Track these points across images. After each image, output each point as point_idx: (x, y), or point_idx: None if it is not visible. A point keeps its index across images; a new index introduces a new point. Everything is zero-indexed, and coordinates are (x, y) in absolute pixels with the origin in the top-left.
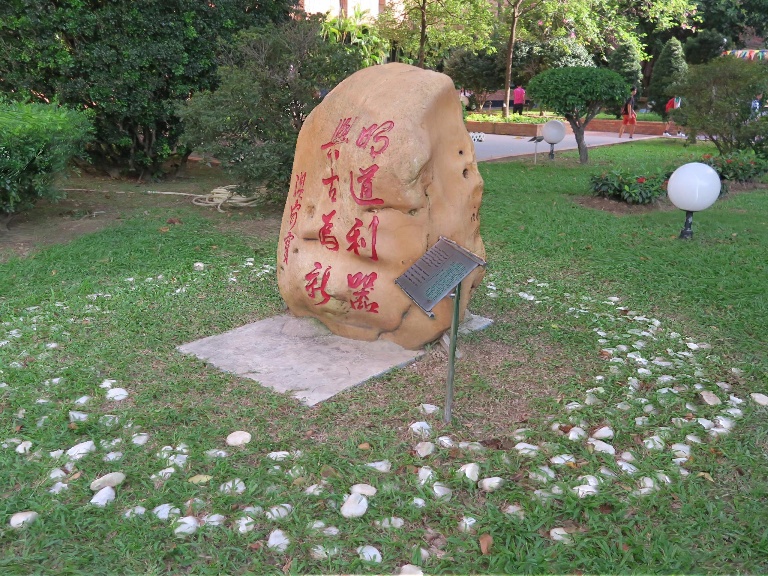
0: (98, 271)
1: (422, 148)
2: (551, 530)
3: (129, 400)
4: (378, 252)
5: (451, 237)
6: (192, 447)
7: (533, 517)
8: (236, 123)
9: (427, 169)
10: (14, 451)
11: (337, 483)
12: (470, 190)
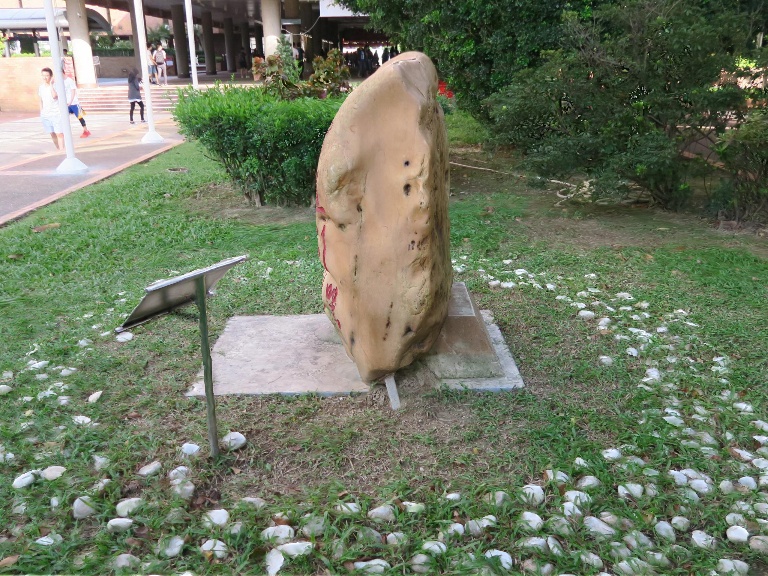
0: None
1: (344, 155)
2: None
3: (124, 344)
4: (327, 265)
5: (381, 264)
6: (67, 390)
7: (70, 570)
8: (533, 112)
9: (355, 180)
10: (25, 352)
11: (58, 458)
12: (408, 211)
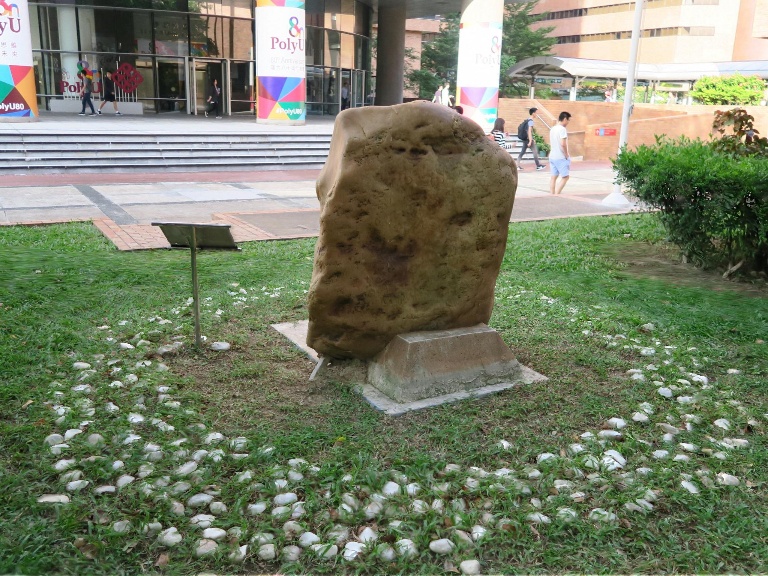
0: (625, 300)
1: None
2: (75, 353)
3: None
4: None
5: None
6: None
7: None
8: None
9: None
10: None
11: None
12: None
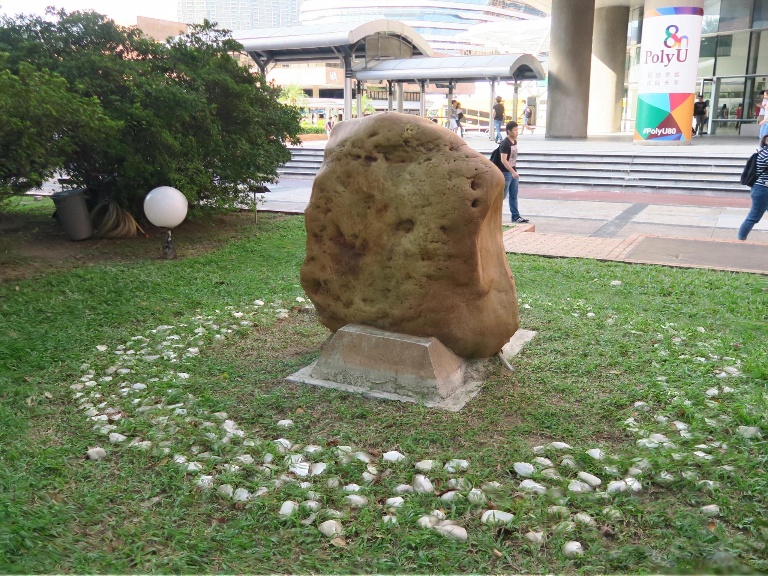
0: None
1: None
2: None
3: None
4: None
5: None
6: None
7: None
8: None
9: None
10: None
11: None
12: None
